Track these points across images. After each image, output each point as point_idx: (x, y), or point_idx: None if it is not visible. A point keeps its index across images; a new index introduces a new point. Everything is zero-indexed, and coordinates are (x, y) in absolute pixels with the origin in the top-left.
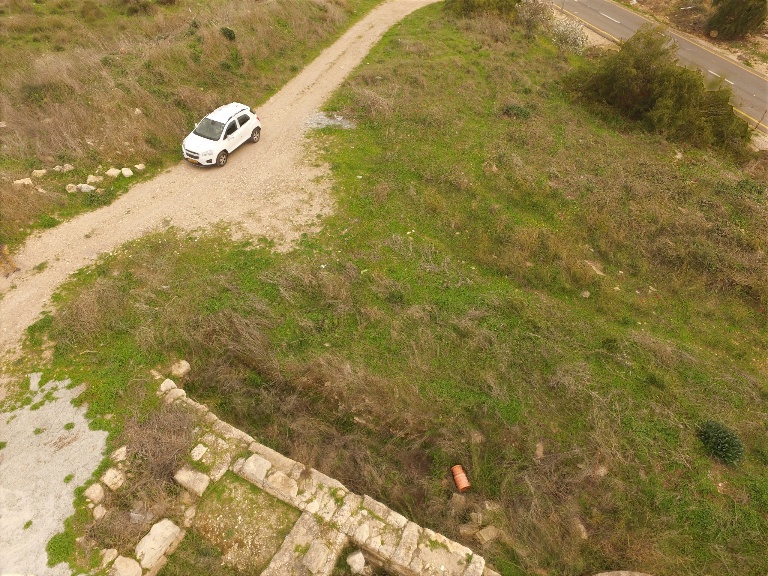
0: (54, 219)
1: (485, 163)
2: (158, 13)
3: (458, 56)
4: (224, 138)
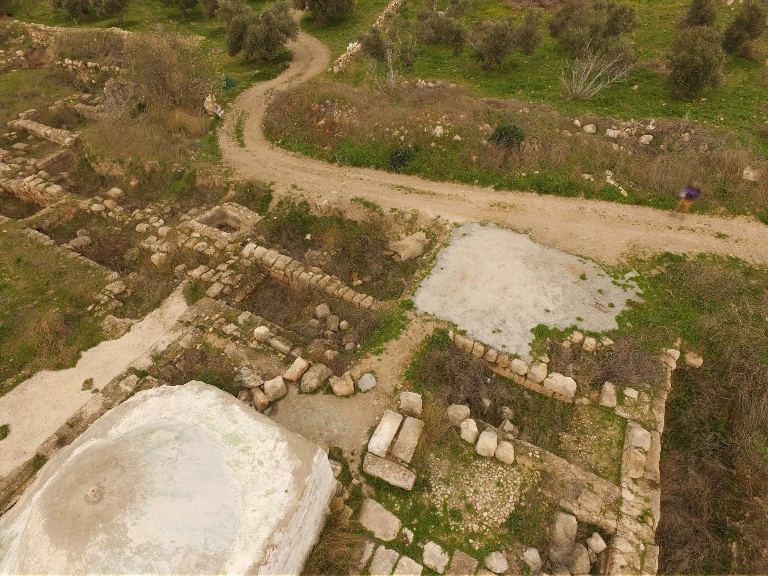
0: None
1: None
2: None
3: None
4: None
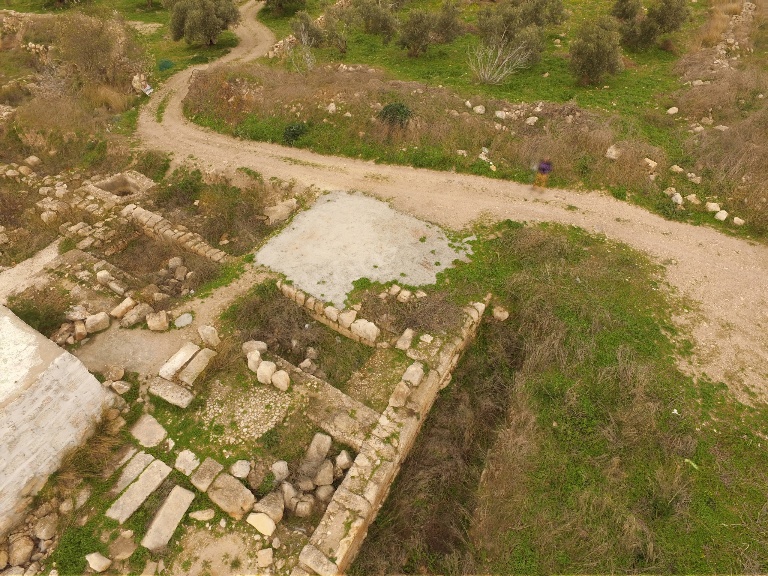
0: (625, 195)
1: None
2: None
3: None
4: None
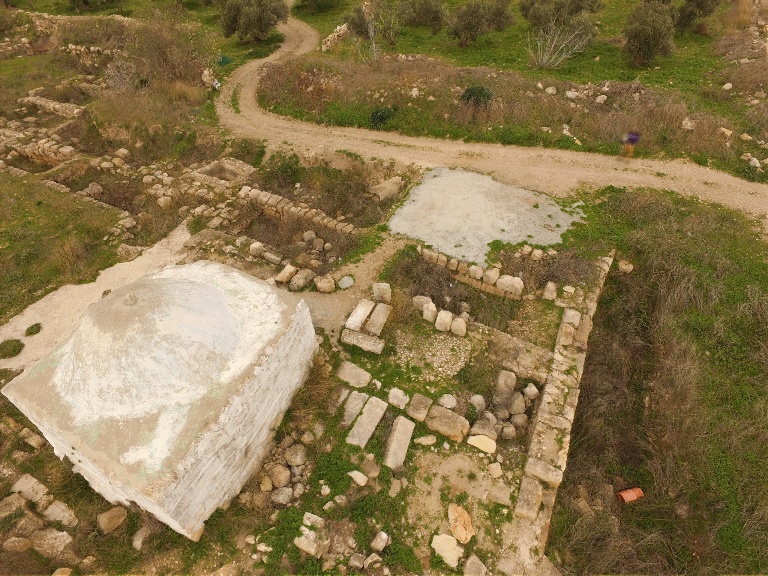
0: (707, 161)
1: None
2: None
3: None
4: None
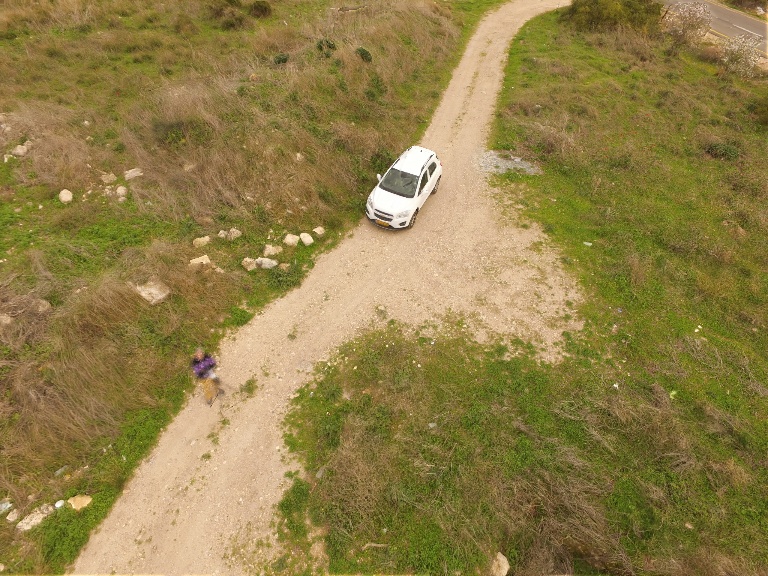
0: (245, 312)
1: (724, 222)
2: (260, 28)
3: (611, 78)
4: (418, 194)
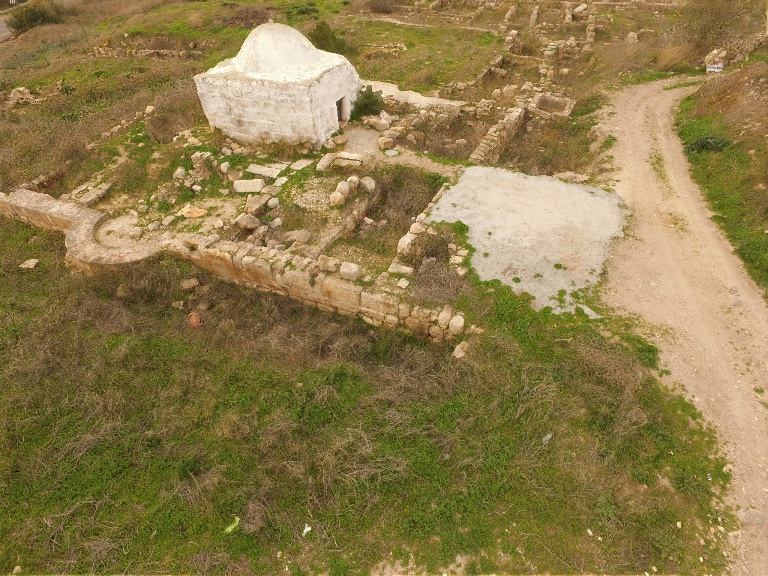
0: None
1: None
2: None
3: None
4: None
